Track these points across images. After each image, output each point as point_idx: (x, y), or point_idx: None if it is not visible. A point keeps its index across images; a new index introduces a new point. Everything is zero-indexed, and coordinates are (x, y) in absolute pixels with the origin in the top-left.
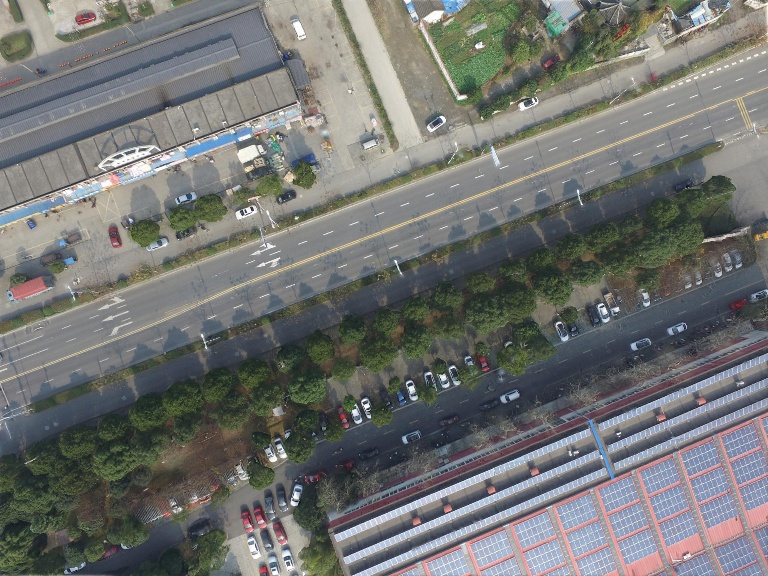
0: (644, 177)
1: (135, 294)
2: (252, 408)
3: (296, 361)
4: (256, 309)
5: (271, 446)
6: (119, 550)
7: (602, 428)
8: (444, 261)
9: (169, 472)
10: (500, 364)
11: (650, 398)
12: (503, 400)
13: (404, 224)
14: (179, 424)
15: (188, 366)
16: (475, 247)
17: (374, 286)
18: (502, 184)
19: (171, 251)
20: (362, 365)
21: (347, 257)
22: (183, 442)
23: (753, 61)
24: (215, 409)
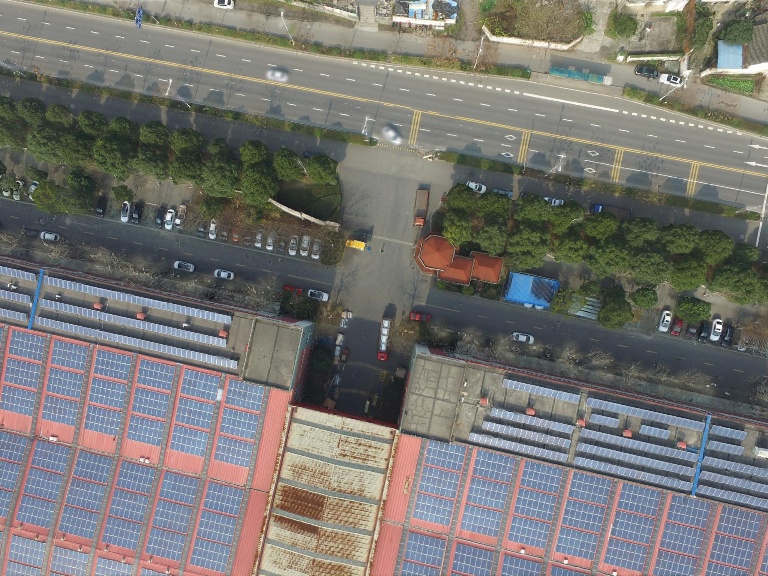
0: (281, 126)
1: None
2: None
3: None
4: None
5: None
6: None
7: (47, 282)
8: (72, 94)
9: None
10: None
11: (103, 286)
12: (41, 235)
13: (59, 43)
14: None
15: None
16: (104, 98)
17: (5, 79)
18: (159, 59)
19: None
20: None
21: None
22: None
23: (456, 86)
24: None
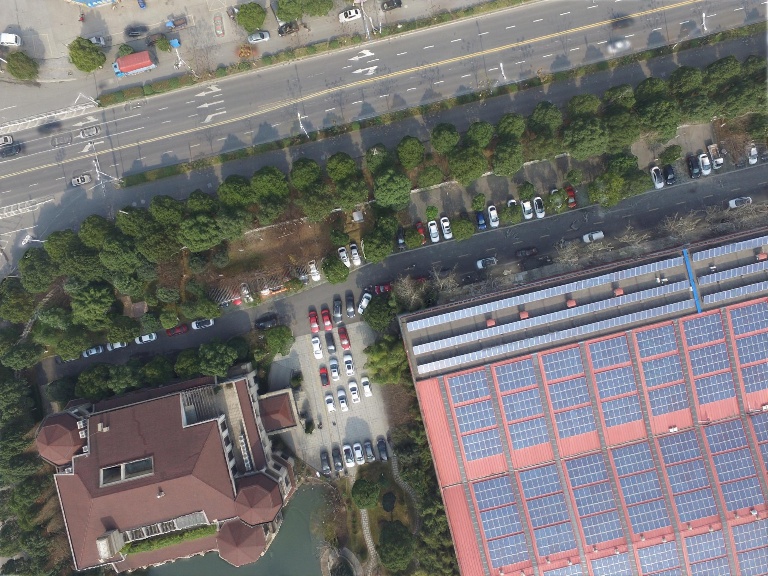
0: None
1: (232, 85)
2: (336, 201)
3: (386, 158)
4: (347, 115)
5: (346, 251)
6: (189, 330)
7: (696, 259)
8: (543, 90)
9: (244, 262)
10: (592, 192)
11: (752, 236)
12: (586, 239)
13: (507, 47)
14: (265, 202)
15: (274, 162)
16: (578, 80)
17: (468, 107)
18: (615, 17)
19: (271, 47)
20: (450, 174)
21: (445, 74)
22: (267, 219)
23: None
24: (300, 197)
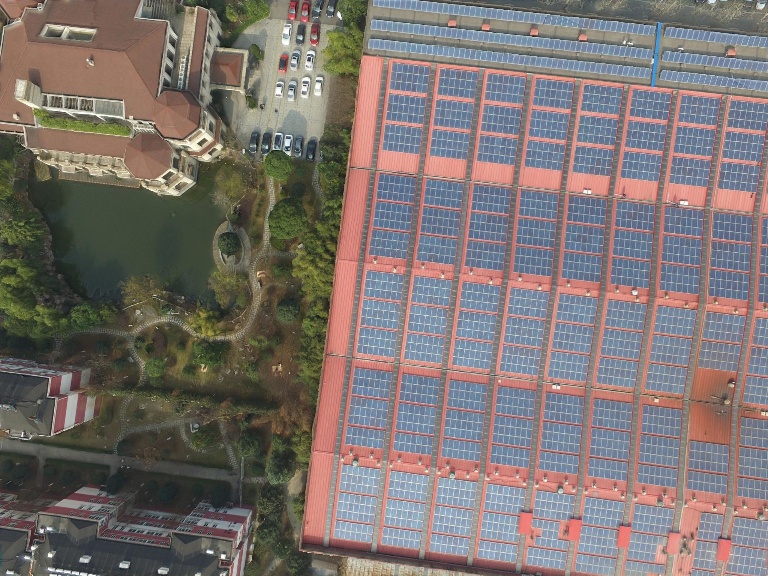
0: None
1: None
2: None
3: None
4: None
5: None
6: None
7: (668, 35)
8: None
9: None
10: None
11: None
12: None
13: None
14: None
15: None
16: None
17: None
18: None
19: None
20: None
21: None
22: None
23: None
24: None
